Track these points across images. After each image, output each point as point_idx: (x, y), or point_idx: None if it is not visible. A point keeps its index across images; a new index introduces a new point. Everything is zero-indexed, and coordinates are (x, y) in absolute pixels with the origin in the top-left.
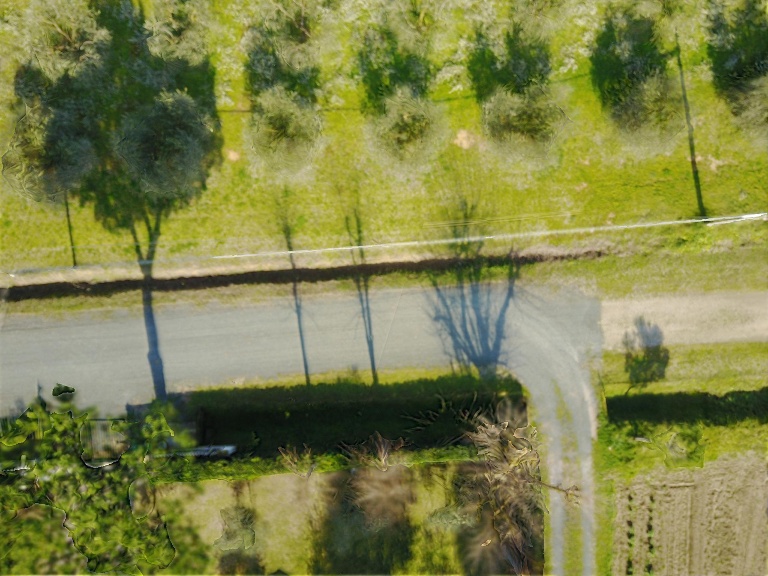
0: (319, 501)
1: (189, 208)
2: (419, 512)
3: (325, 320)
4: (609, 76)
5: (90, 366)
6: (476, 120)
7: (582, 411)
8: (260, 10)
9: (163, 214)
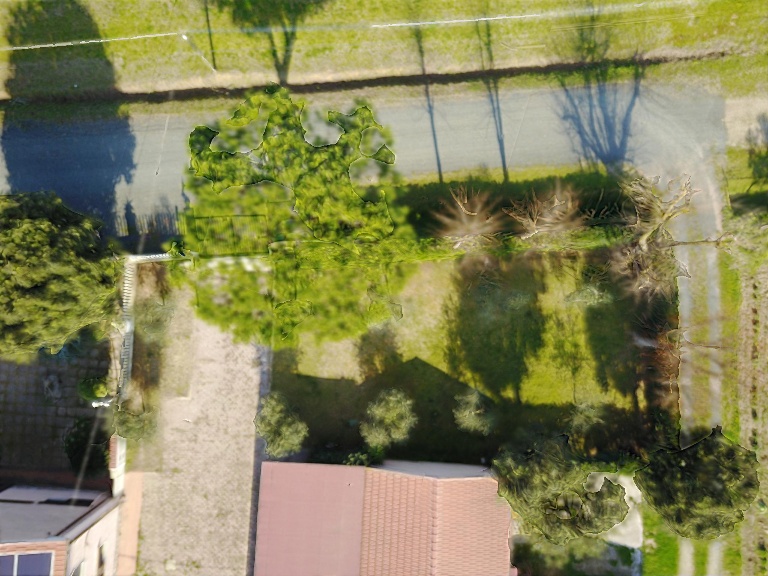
0: (454, 292)
1: (324, 13)
2: (551, 301)
3: (457, 120)
4: None
5: None
6: None
7: (707, 205)
8: None
9: (299, 19)
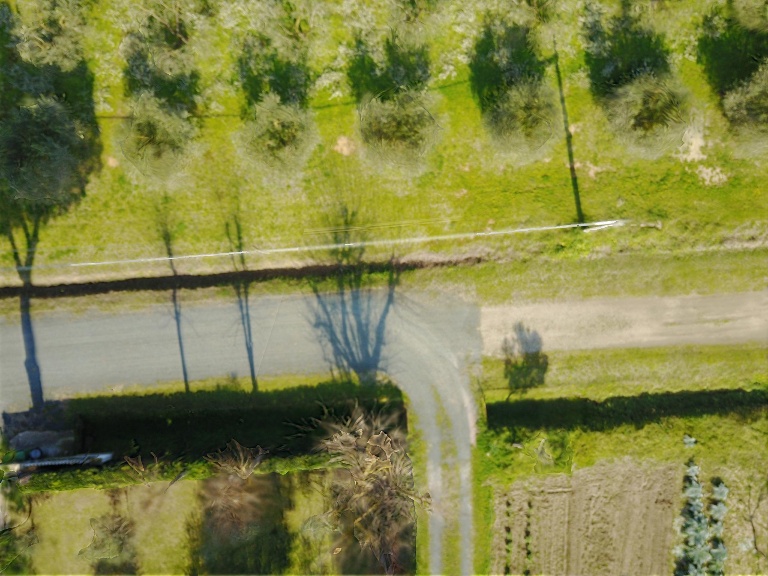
0: (197, 509)
1: (68, 215)
2: (297, 519)
3: (205, 327)
4: (488, 83)
5: None
6: (356, 126)
7: (462, 417)
8: (136, 16)
9: (41, 221)
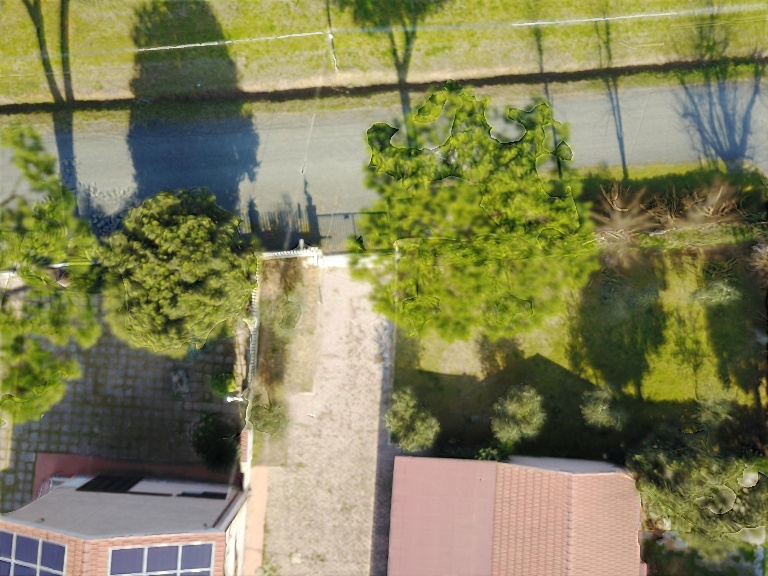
0: (575, 288)
1: (444, 12)
2: (672, 298)
3: (577, 118)
4: None
5: (353, 163)
6: None
7: None
8: None
9: (420, 18)
